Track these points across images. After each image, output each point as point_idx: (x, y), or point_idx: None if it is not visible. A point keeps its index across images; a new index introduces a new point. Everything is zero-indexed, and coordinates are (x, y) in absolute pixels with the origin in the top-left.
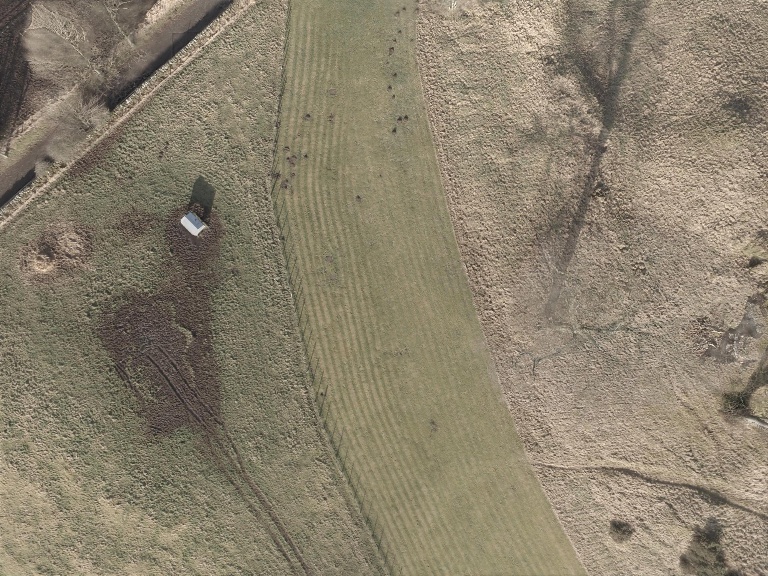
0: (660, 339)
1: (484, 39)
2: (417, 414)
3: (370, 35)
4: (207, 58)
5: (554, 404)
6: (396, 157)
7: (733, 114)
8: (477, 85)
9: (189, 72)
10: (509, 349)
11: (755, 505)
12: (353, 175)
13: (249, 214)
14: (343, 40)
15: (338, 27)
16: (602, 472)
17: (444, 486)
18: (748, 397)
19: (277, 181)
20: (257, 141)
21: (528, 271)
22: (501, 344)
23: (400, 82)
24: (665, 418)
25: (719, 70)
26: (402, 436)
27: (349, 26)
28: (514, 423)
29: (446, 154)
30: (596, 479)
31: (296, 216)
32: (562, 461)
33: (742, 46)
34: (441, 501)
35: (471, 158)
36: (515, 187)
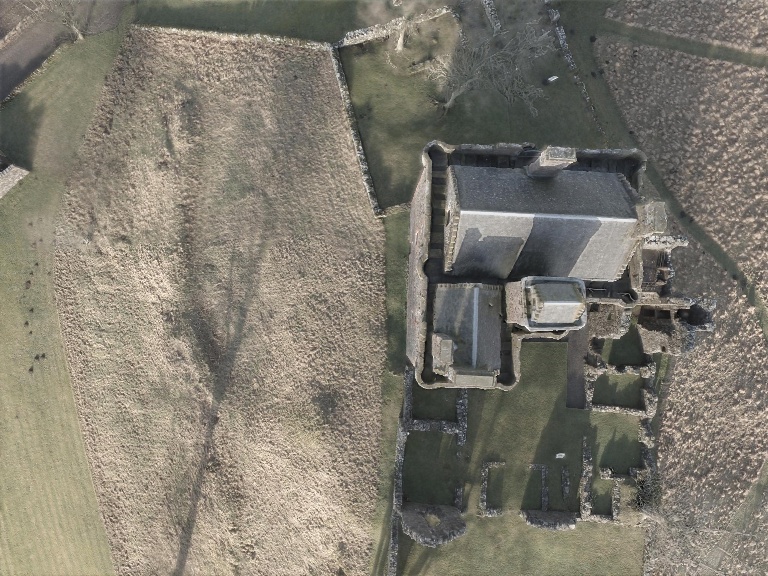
0: None
1: (117, 280)
2: None
3: (6, 267)
4: None
5: None
6: (33, 397)
7: (318, 411)
8: (110, 329)
9: None
10: None
11: None
12: None
13: None
14: None
15: None
16: None
17: None
18: None
19: None
20: None
21: (159, 531)
22: None
23: (37, 318)
24: None
25: (314, 356)
26: None
27: None
28: None
29: (83, 397)
30: None
31: None
32: None
33: (337, 332)
34: None
35: (105, 405)
36: (147, 441)
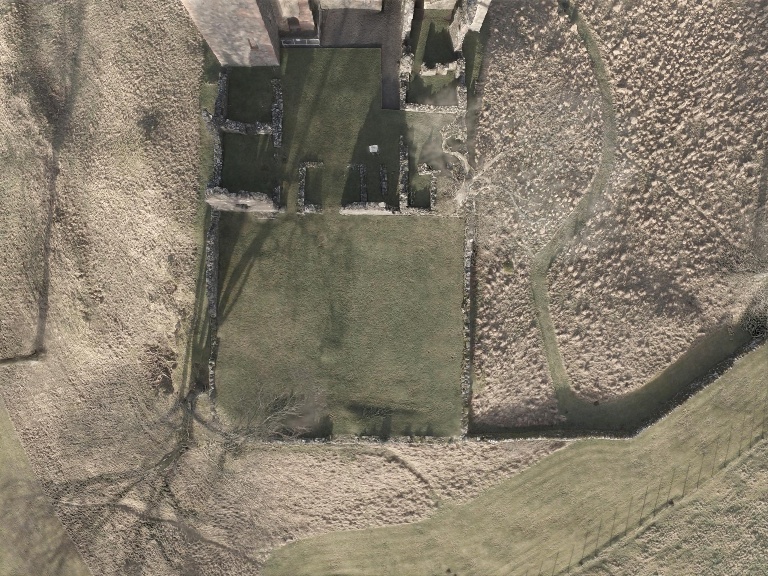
0: (123, 370)
1: None
2: None
3: None
4: None
5: (57, 440)
6: None
7: (142, 131)
8: None
9: None
10: (15, 384)
11: (227, 541)
12: None
13: None
14: None
15: None
16: (106, 509)
17: None
18: (192, 430)
19: None
20: None
21: (20, 302)
22: (7, 379)
23: None
24: (140, 452)
25: (138, 84)
26: None
27: None
28: (29, 461)
29: None
30: (104, 517)
31: None
32: (75, 499)
33: (158, 57)
34: None
35: None
36: (2, 213)
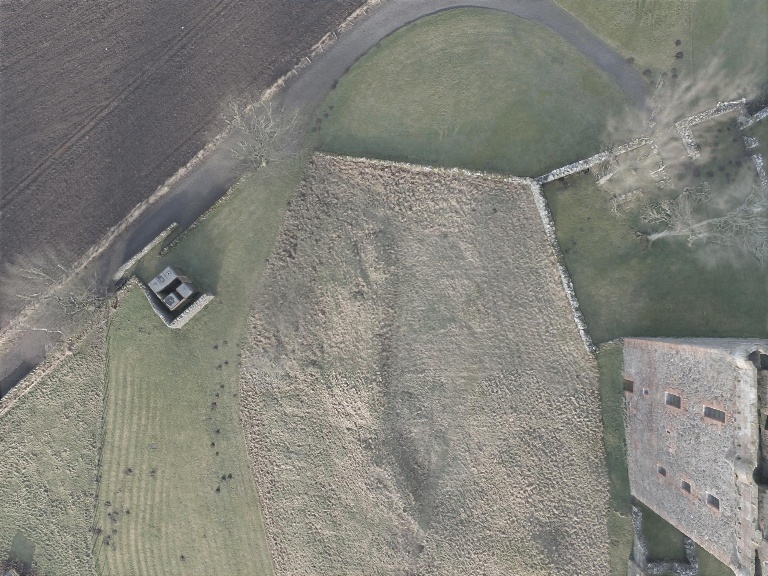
0: None
1: (306, 404)
2: None
3: (191, 389)
4: (24, 409)
5: None
6: (220, 517)
7: (541, 550)
8: (300, 451)
9: (6, 423)
10: None
11: None
12: (176, 533)
13: (70, 571)
14: (164, 393)
15: (159, 379)
16: None
17: None
18: None
19: (99, 537)
20: (77, 495)
21: None
22: None
23: (223, 439)
24: None
25: (531, 492)
26: None
27: (170, 378)
28: None
29: (271, 517)
30: None
31: (119, 574)
32: None
33: (554, 469)
34: None
35: (295, 526)
36: (340, 562)
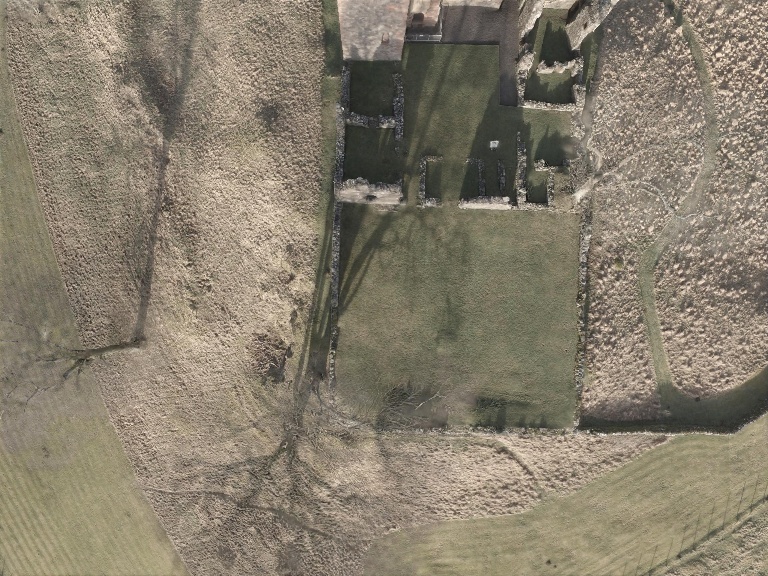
0: (229, 359)
1: (68, 47)
2: (28, 440)
3: None
4: None
5: (153, 427)
6: None
7: (262, 123)
8: (64, 96)
9: None
10: (111, 371)
11: (329, 529)
12: None
13: None
14: None
15: None
16: (202, 497)
17: (61, 514)
18: (301, 418)
19: None
20: None
21: (120, 289)
22: (103, 366)
23: None
24: (243, 440)
25: (256, 76)
26: (15, 464)
27: None
28: (123, 447)
29: (41, 169)
30: (199, 504)
31: None
32: (169, 486)
33: (277, 50)
34: (60, 530)
35: (63, 172)
36: (104, 202)
